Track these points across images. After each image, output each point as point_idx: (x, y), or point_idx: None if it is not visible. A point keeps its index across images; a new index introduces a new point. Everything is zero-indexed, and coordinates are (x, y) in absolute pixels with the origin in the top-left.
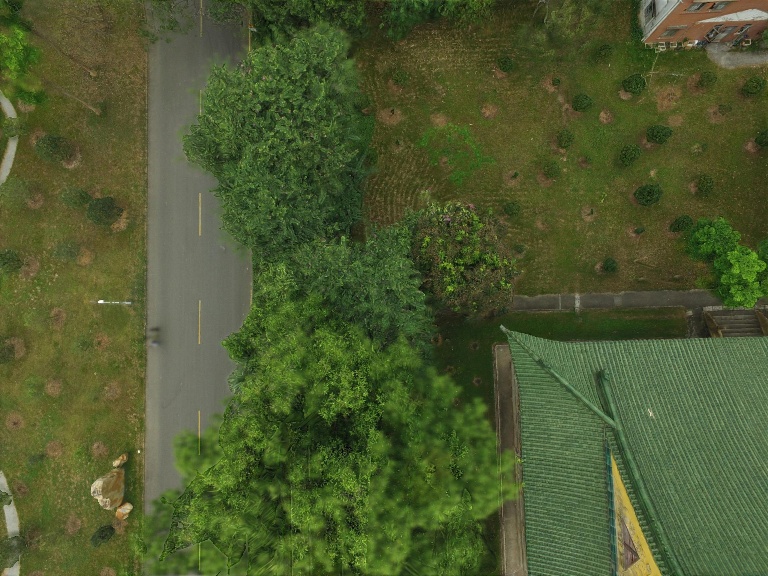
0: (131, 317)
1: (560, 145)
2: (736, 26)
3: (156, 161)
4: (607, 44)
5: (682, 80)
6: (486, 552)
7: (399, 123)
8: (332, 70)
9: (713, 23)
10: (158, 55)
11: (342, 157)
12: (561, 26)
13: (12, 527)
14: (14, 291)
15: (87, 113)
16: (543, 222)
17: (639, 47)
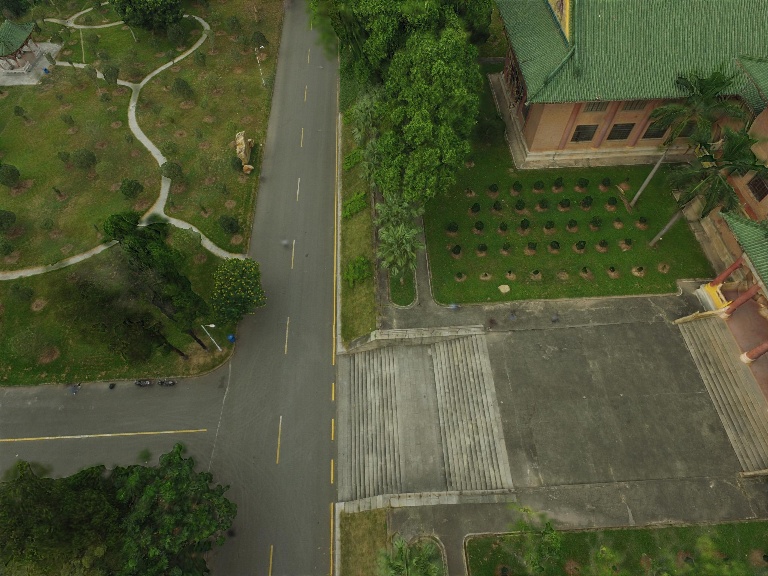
0: (264, 91)
1: None
2: None
3: (285, 40)
4: None
5: None
6: None
7: None
8: None
9: None
10: (290, 9)
11: None
12: None
13: (165, 183)
14: (193, 83)
15: (250, 23)
16: None
17: None
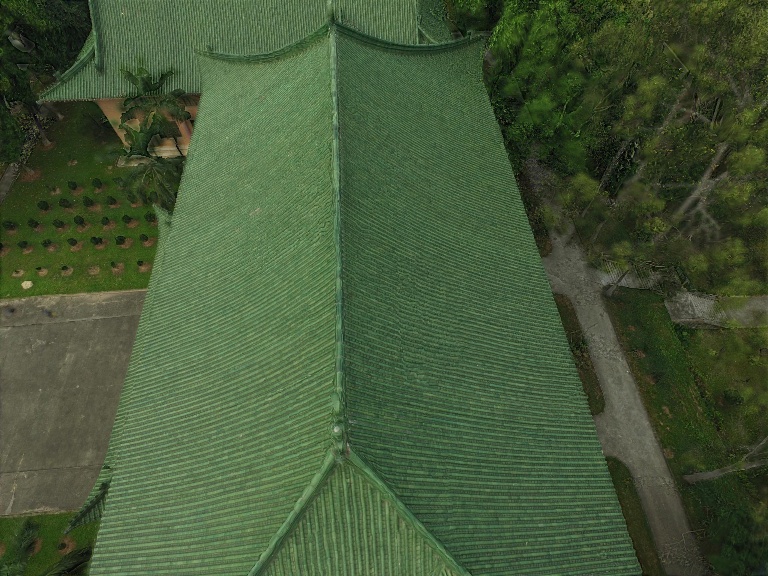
0: None
1: None
2: None
3: None
4: None
5: None
6: (87, 113)
7: None
8: None
9: None
10: None
11: None
12: None
13: None
14: None
15: None
16: None
17: None
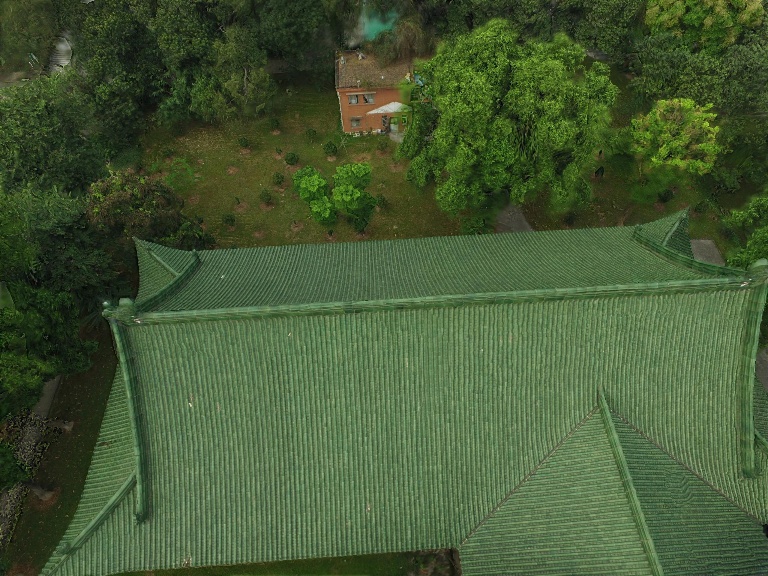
0: None
1: (274, 182)
2: (397, 117)
3: None
4: (321, 134)
5: (372, 151)
6: None
7: (165, 179)
8: (56, 98)
9: (378, 114)
10: None
11: (66, 157)
12: (232, 91)
13: None
14: None
15: None
16: (259, 232)
17: (342, 135)
